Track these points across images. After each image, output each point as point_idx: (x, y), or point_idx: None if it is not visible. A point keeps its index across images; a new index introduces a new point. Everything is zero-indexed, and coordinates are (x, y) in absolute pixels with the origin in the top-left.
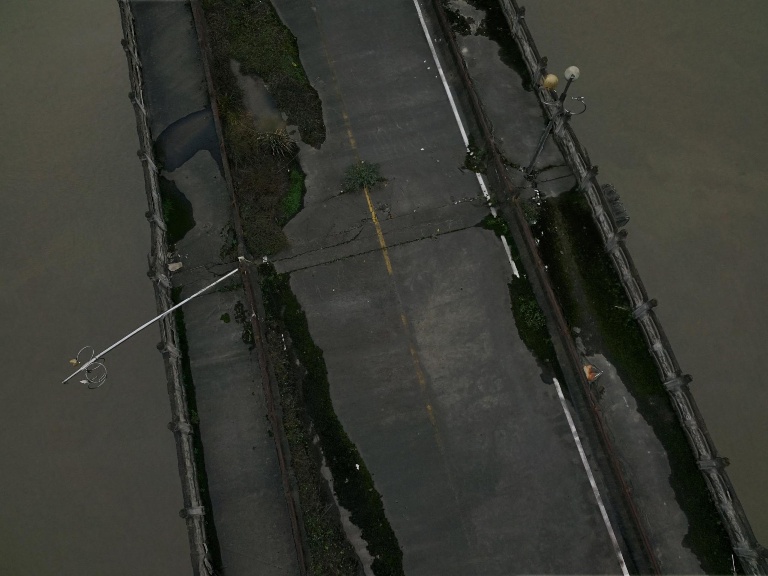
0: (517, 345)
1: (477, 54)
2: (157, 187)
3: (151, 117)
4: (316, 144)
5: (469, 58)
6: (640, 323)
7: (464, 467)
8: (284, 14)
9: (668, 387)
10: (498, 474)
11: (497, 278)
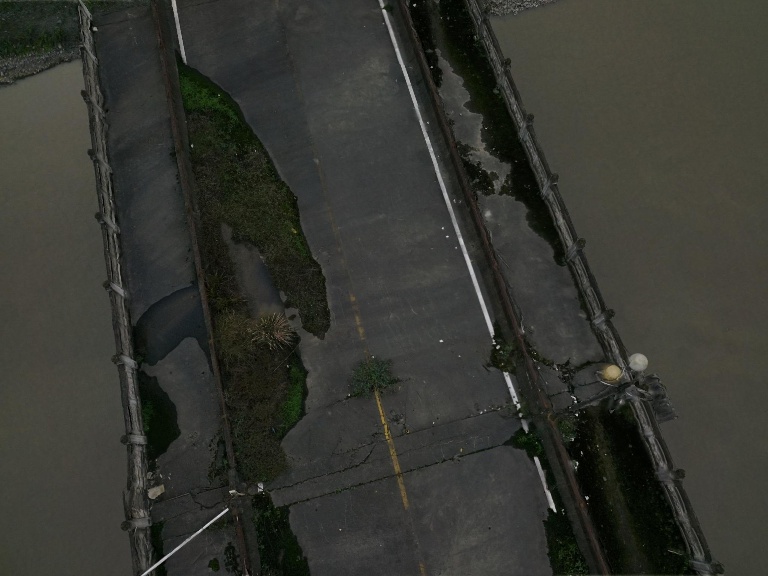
0: None
1: (502, 219)
2: (136, 389)
3: (130, 296)
4: (319, 333)
5: (493, 224)
6: (699, 575)
7: None
8: (282, 167)
9: None
10: None
11: (530, 513)
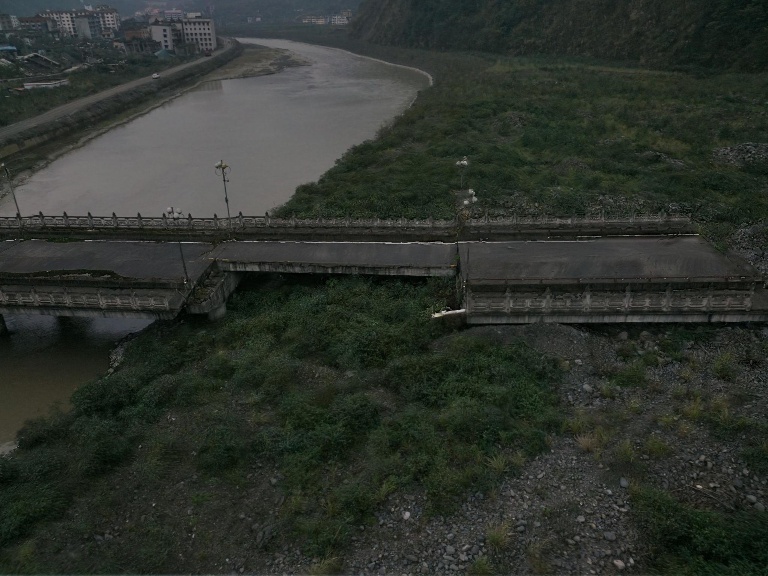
0: None
1: None
2: None
3: None
4: None
5: None
6: (95, 226)
7: (81, 256)
8: None
9: (116, 225)
10: (92, 252)
11: None
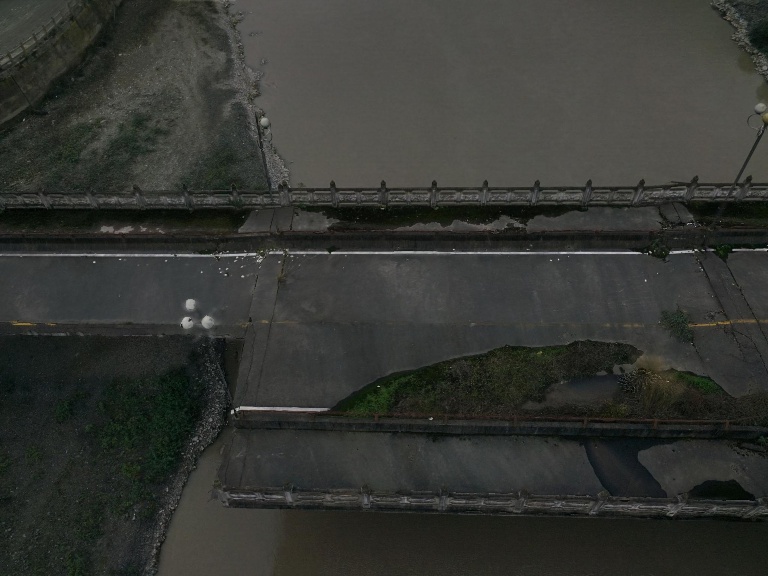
0: None
1: (547, 229)
2: None
3: None
4: (638, 353)
5: None
6: None
7: None
8: (473, 350)
9: None
10: None
11: None
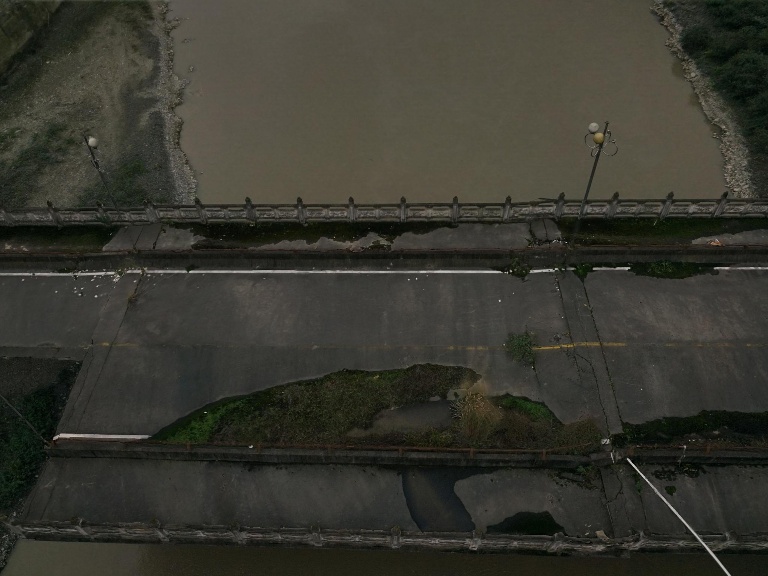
0: (688, 282)
1: (412, 246)
2: None
3: None
4: (476, 377)
5: None
6: (669, 216)
7: None
8: (309, 374)
9: (718, 214)
10: None
11: (631, 280)
